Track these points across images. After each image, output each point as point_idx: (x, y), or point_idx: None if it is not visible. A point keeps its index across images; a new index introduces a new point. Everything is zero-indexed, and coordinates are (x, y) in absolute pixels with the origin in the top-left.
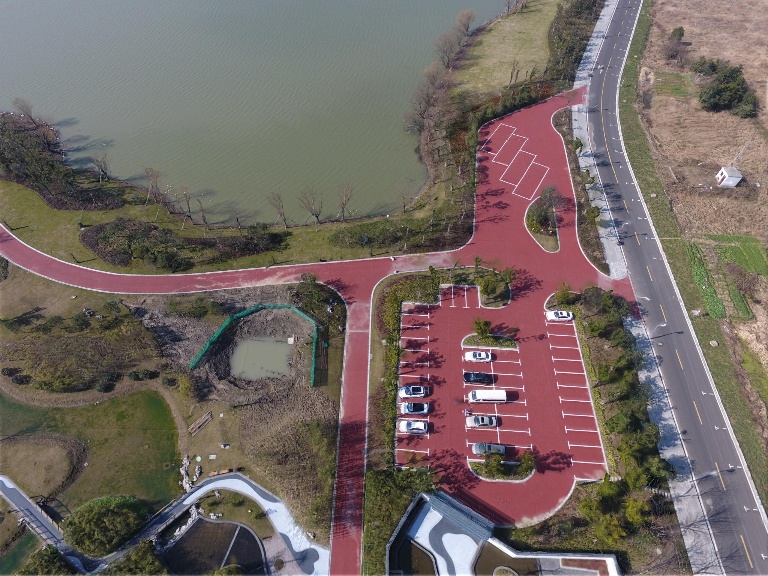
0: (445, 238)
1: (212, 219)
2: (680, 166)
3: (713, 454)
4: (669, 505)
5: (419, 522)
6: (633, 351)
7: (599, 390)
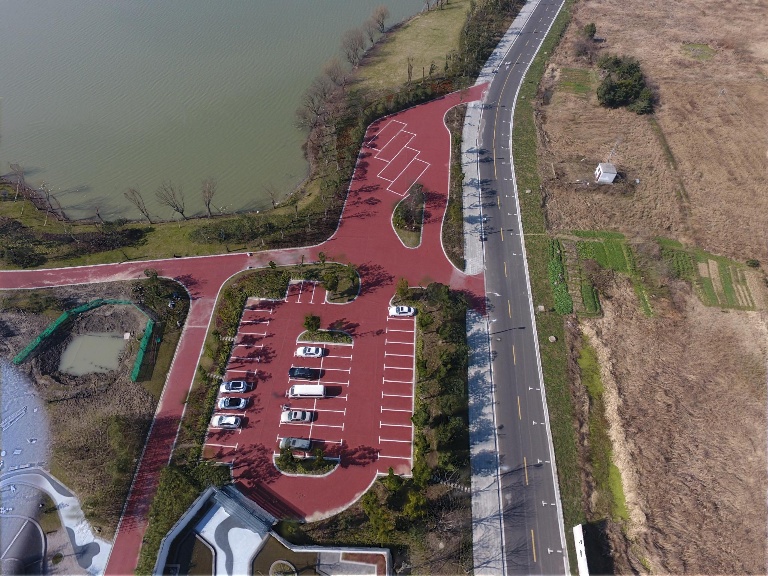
0: (306, 234)
1: (80, 215)
2: (563, 162)
3: (524, 449)
4: (465, 499)
5: (209, 516)
6: (461, 346)
7: (423, 385)
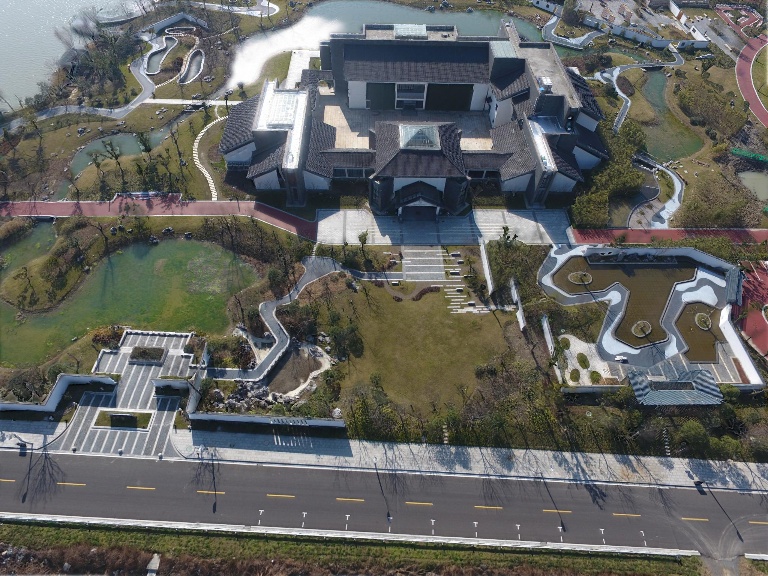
0: None
1: None
2: None
3: None
4: None
5: (710, 273)
6: None
7: None
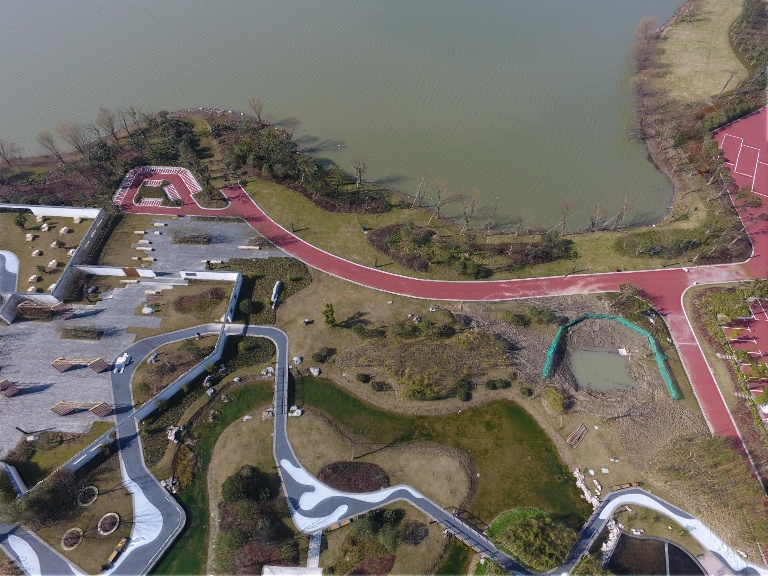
0: (729, 250)
1: (479, 225)
2: None
3: None
4: None
5: None
6: None
7: None
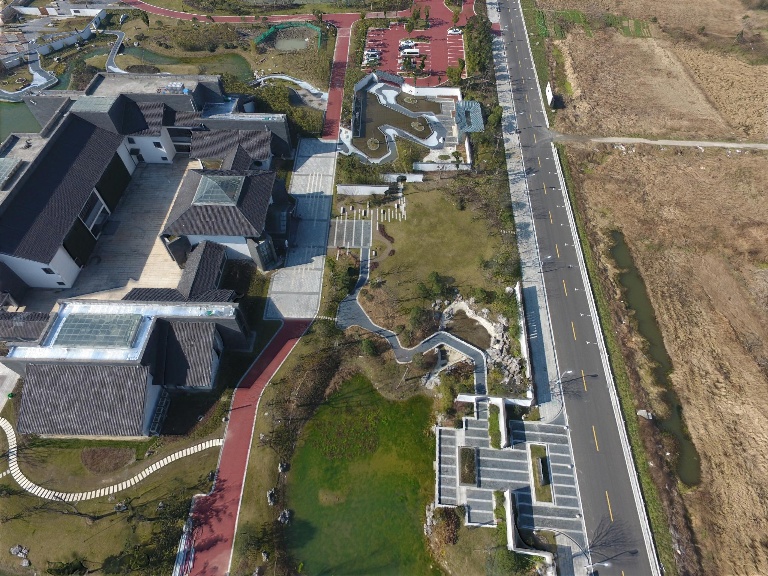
0: (395, 6)
1: (257, 2)
2: None
3: (522, 74)
4: (494, 85)
5: (371, 87)
6: None
7: None
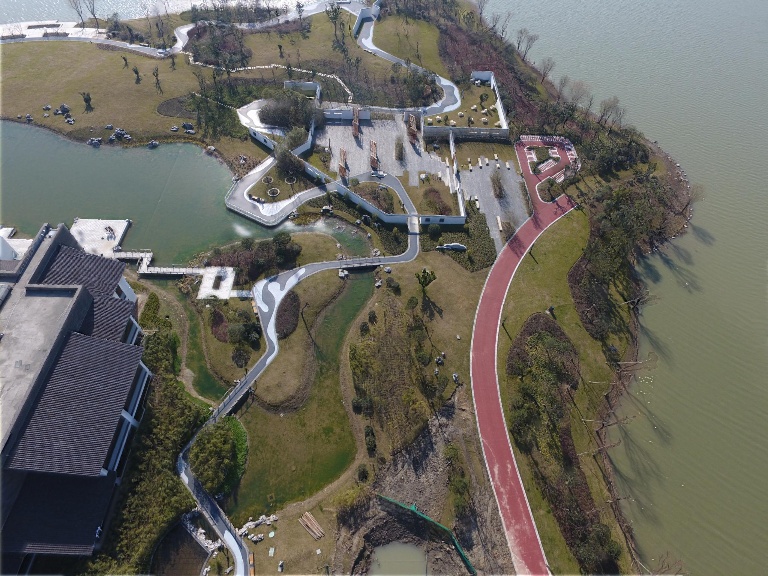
0: None
1: (616, 453)
2: None
3: None
4: None
5: None
6: None
7: None
